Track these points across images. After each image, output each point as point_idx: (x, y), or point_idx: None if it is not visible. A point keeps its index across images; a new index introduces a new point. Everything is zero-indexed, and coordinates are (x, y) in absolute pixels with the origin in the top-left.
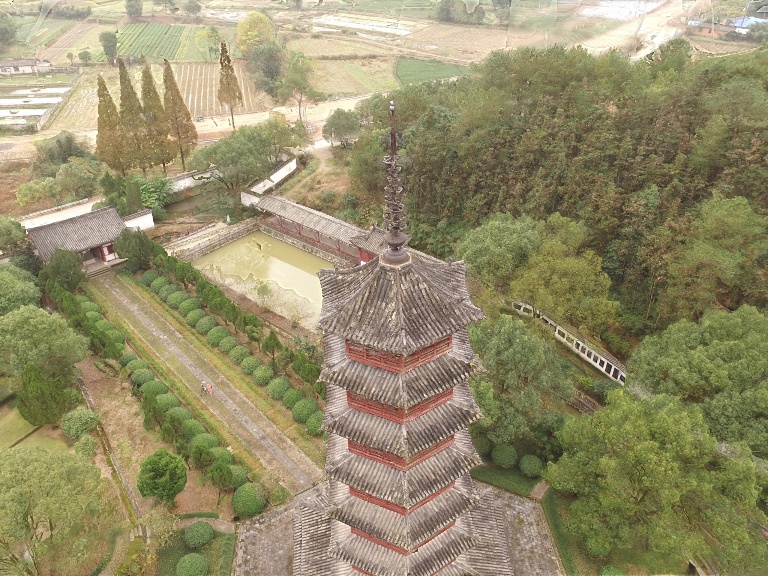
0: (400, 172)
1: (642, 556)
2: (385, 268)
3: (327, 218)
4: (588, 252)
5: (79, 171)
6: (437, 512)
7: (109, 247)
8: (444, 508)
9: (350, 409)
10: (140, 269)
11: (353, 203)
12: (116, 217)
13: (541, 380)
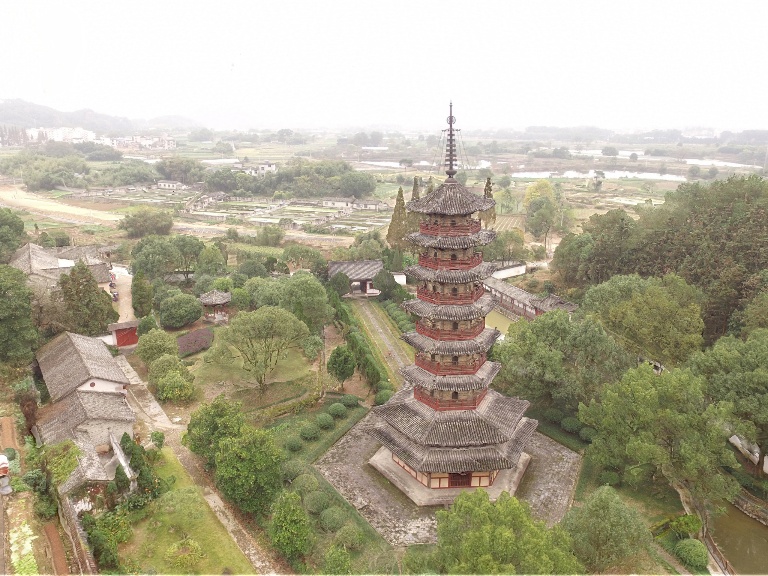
0: (584, 261)
1: (645, 497)
2: (443, 185)
3: (522, 290)
4: (692, 304)
5: (372, 246)
6: (458, 348)
7: (371, 284)
8: (463, 347)
9: (419, 266)
10: (385, 300)
11: (550, 288)
12: (381, 267)
13: (604, 363)
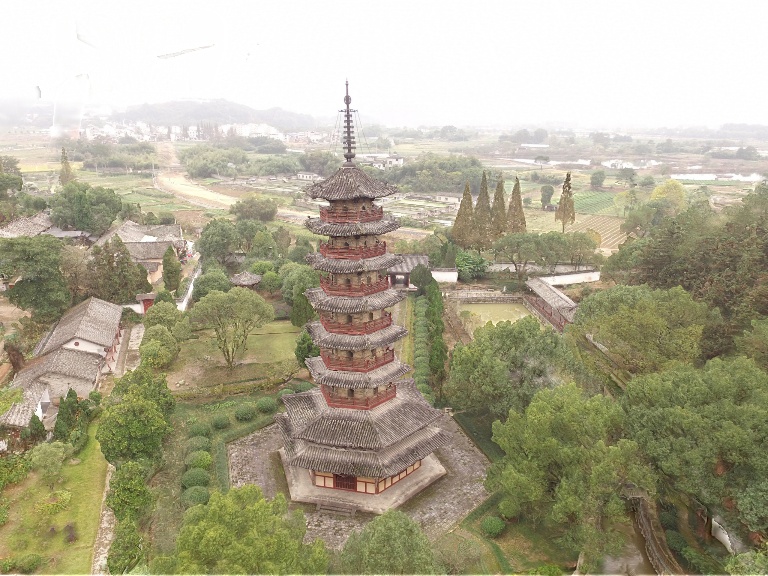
0: (629, 269)
1: (540, 538)
2: (340, 169)
3: (561, 296)
4: (693, 325)
5: (435, 241)
6: (347, 342)
7: None
8: (352, 342)
9: (321, 254)
10: None
11: None
12: (426, 261)
13: (550, 381)
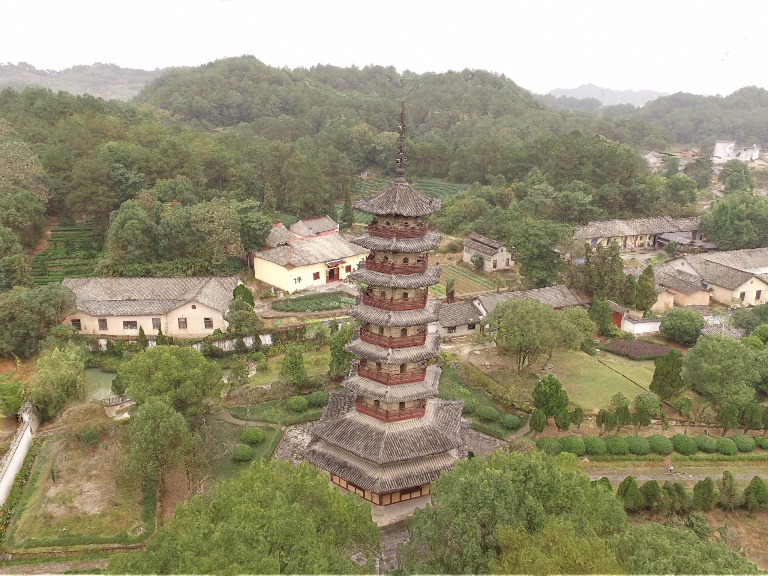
0: None
1: None
2: None
3: None
4: None
5: None
6: None
7: None
8: None
9: None
10: None
11: None
12: None
13: None
